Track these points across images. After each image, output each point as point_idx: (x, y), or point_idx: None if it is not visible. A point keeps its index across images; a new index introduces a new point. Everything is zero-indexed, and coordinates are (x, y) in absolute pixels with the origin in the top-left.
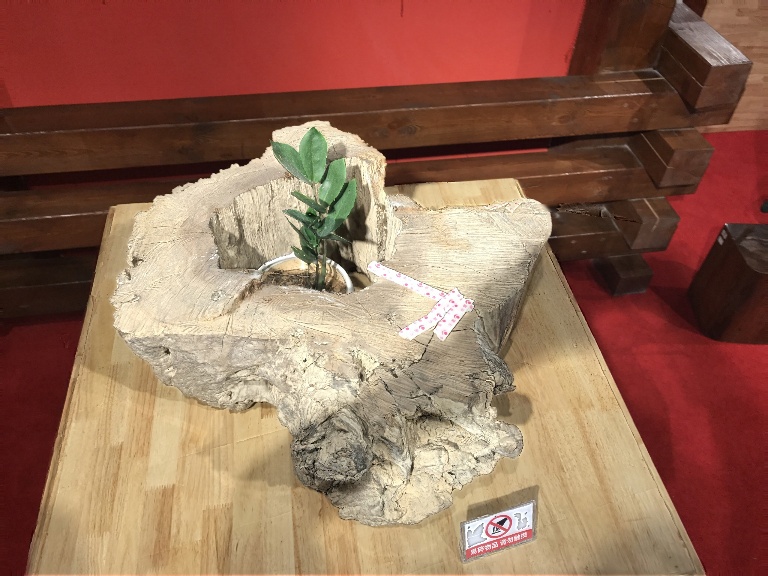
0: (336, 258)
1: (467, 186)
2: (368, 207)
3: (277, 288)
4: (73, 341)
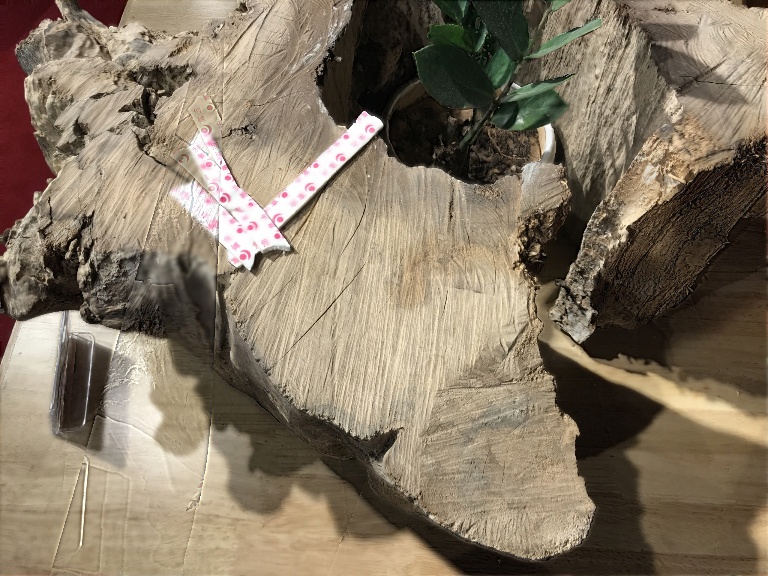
0: None
1: None
2: None
3: None
4: None
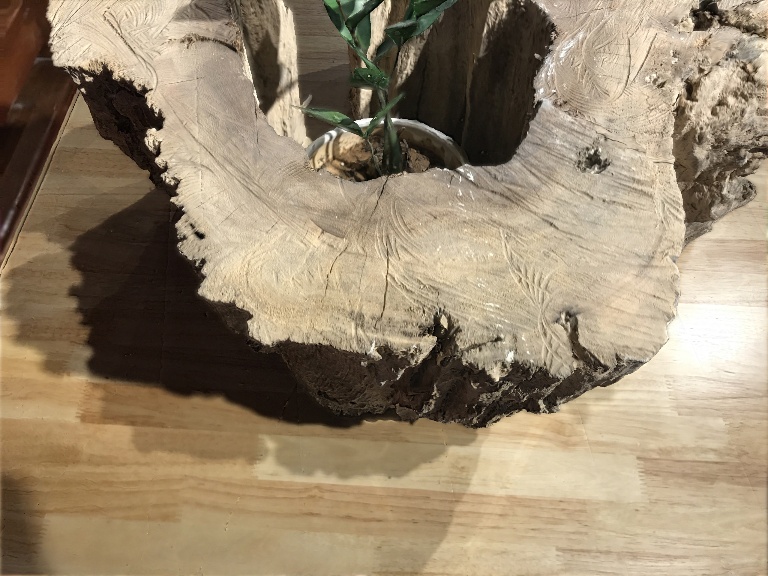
0: None
1: None
2: (275, 27)
3: None
4: None
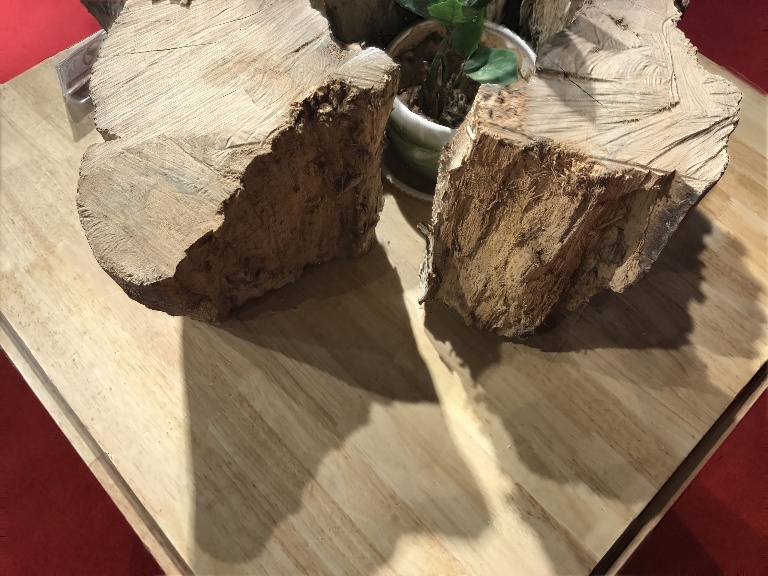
0: None
1: None
2: None
3: None
4: None
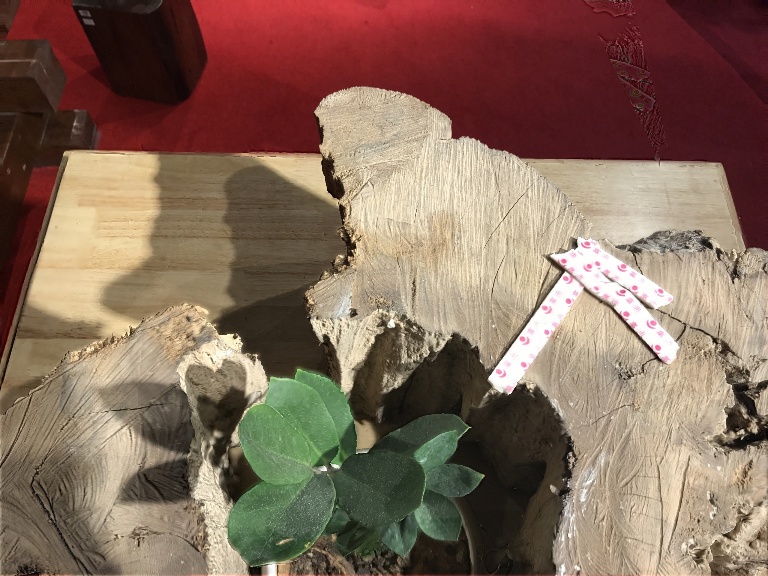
0: (226, 479)
1: (65, 223)
2: (240, 378)
3: None
4: None
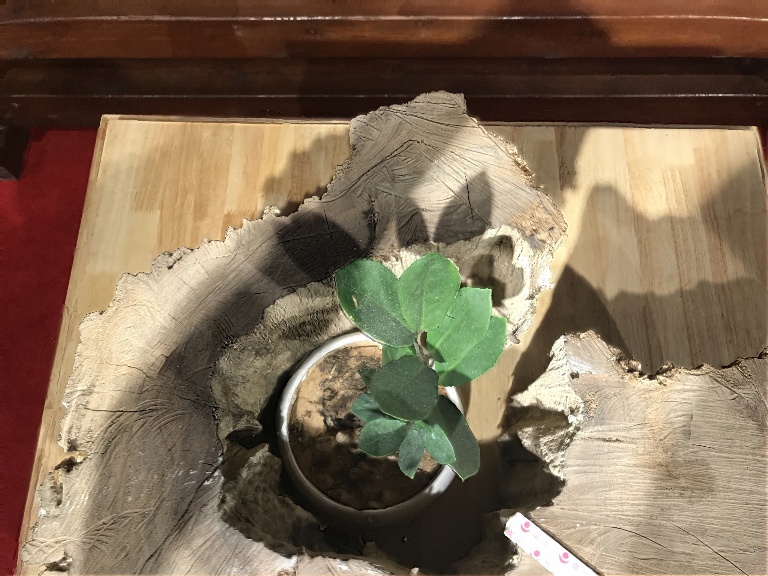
0: None
1: (672, 141)
2: (513, 290)
3: (327, 567)
4: (42, 379)
